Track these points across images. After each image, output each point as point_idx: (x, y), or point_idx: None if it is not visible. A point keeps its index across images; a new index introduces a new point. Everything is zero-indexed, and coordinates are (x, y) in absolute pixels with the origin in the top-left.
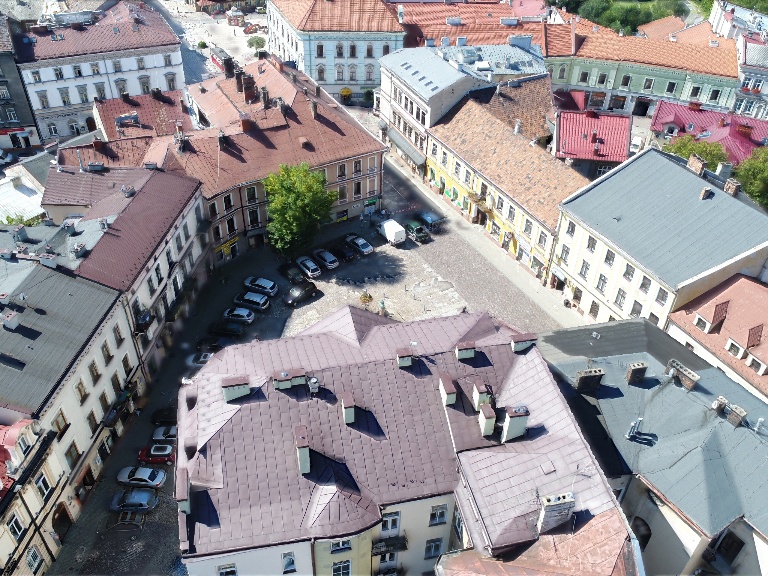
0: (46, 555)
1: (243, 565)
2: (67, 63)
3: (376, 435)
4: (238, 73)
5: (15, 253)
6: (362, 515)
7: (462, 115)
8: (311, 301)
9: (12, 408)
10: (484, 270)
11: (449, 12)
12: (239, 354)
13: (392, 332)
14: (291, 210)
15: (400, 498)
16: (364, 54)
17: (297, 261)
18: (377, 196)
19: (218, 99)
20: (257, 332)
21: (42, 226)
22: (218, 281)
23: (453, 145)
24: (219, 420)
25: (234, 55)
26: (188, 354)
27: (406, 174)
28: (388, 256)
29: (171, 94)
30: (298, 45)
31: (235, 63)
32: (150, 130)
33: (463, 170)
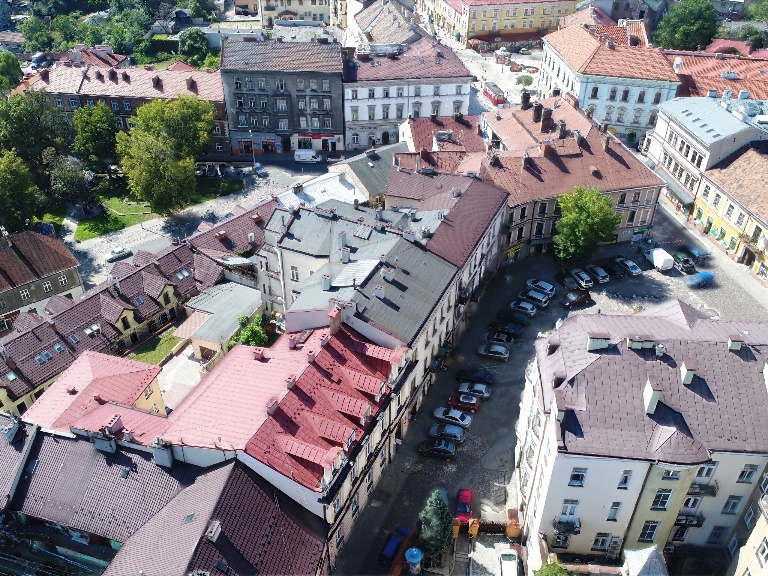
0: (387, 456)
1: (593, 472)
2: (380, 85)
3: (707, 397)
4: (537, 106)
5: (384, 227)
6: (696, 453)
7: (741, 162)
8: (585, 307)
9: (395, 336)
10: (749, 305)
11: (720, 66)
12: (590, 320)
13: (715, 325)
14: (582, 226)
15: (726, 448)
16: (636, 99)
17: (571, 272)
18: (647, 226)
19: (513, 126)
20: (538, 324)
21: (389, 211)
22: (502, 278)
23: (729, 188)
24: (583, 362)
25: (502, 90)
26: (481, 332)
27: (670, 211)
28: (655, 280)
29: (470, 118)
30: (575, 86)
31: (504, 97)
32: (460, 146)
33: (736, 212)
